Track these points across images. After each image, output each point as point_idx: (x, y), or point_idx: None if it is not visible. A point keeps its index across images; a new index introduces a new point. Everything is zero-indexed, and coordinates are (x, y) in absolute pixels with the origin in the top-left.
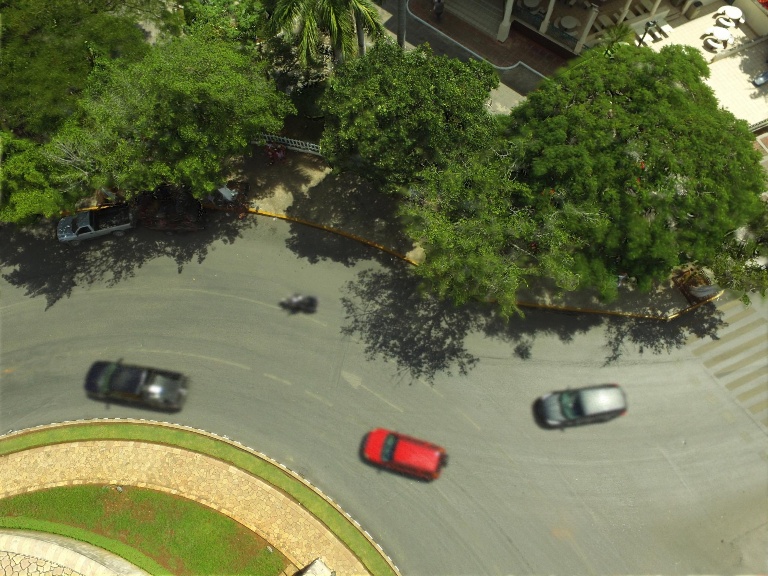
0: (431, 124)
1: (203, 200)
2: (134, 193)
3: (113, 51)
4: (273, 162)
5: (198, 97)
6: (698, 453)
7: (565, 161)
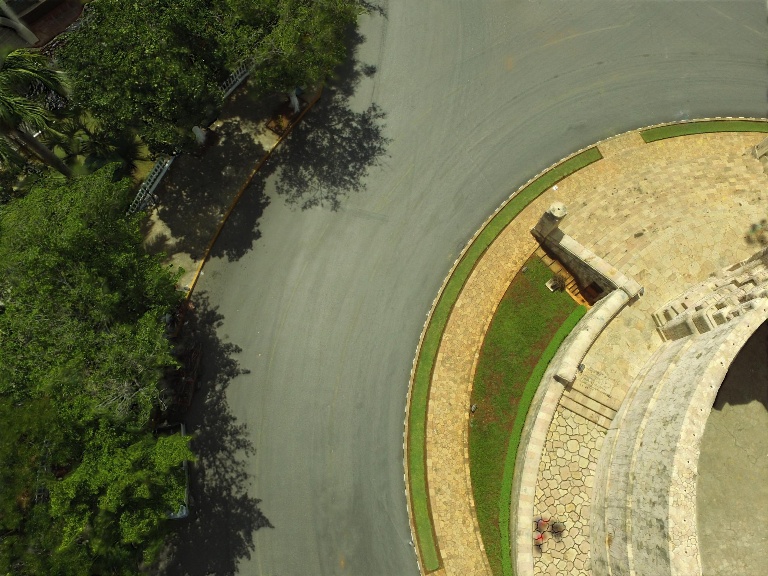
0: (175, 18)
1: None
2: None
3: None
4: None
5: (81, 230)
6: None
7: None
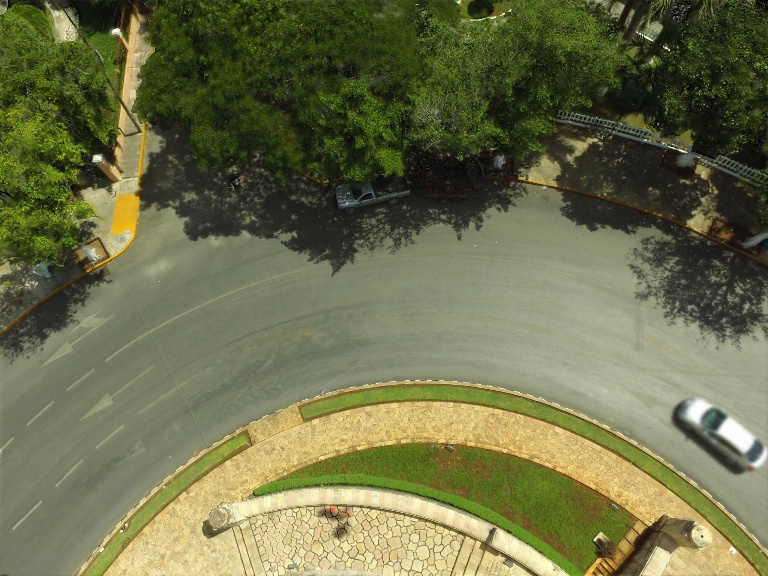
0: None
1: None
2: None
3: (440, 14)
4: None
5: (564, 56)
6: None
7: None
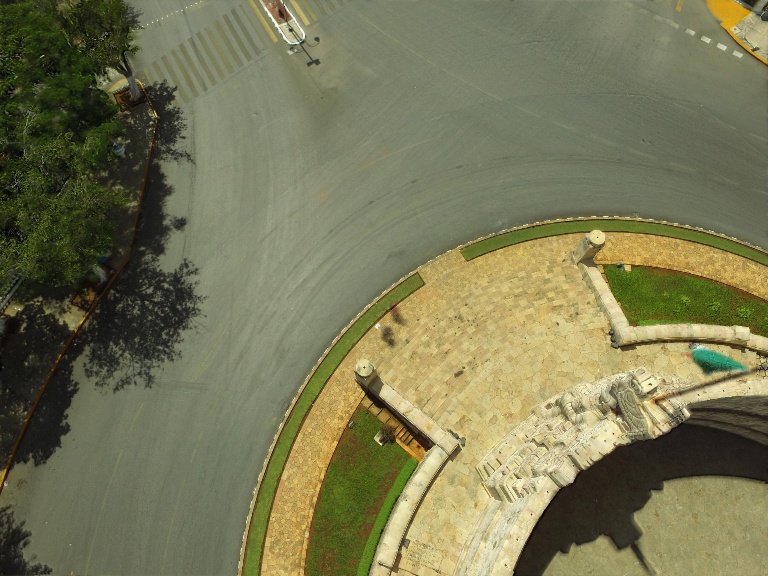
0: None
1: None
2: None
3: None
4: None
5: None
6: (263, 107)
7: None
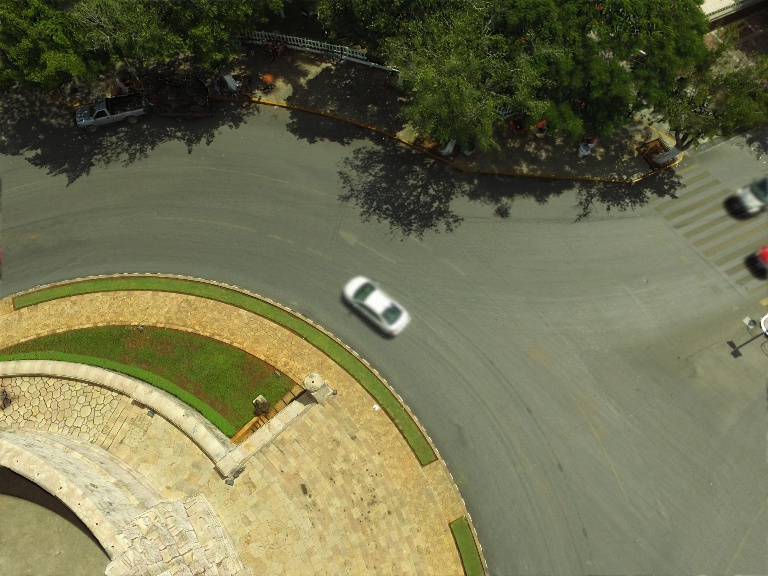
0: None
1: (210, 91)
2: (146, 86)
3: None
4: (273, 59)
5: None
6: (658, 289)
7: (534, 11)
